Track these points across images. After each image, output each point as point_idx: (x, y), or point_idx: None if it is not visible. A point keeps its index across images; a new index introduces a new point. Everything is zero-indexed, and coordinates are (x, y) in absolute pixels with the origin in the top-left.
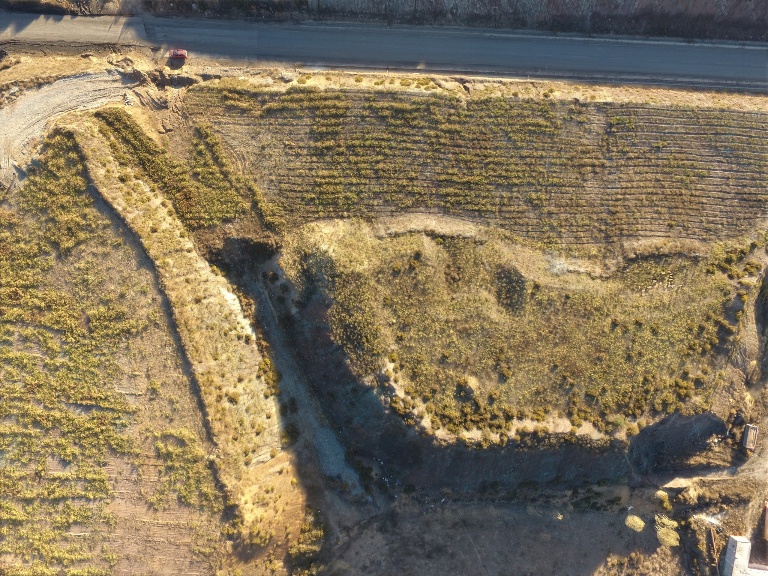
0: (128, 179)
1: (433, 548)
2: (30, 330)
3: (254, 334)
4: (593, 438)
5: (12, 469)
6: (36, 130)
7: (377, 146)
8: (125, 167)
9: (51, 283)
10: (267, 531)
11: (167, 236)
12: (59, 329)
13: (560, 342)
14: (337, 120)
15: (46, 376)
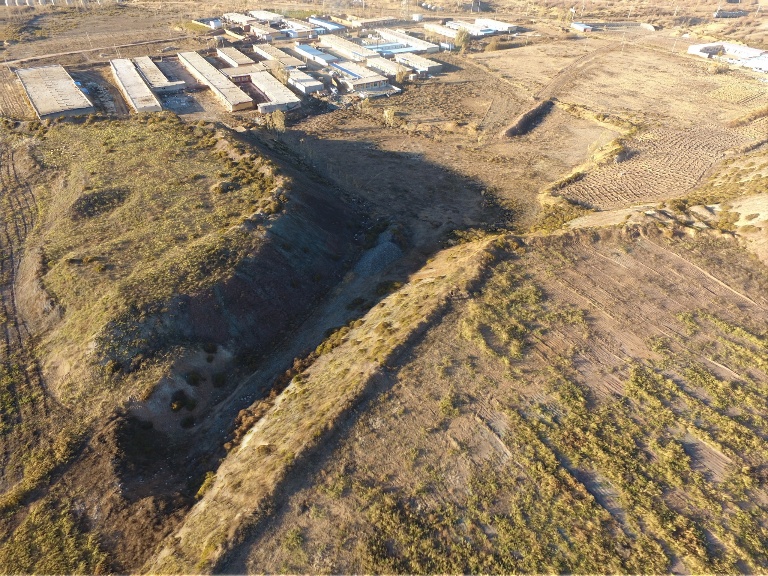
0: None
1: (397, 192)
2: None
3: None
4: None
5: None
6: None
7: None
8: None
9: None
10: None
11: None
12: None
13: None
14: None
15: None
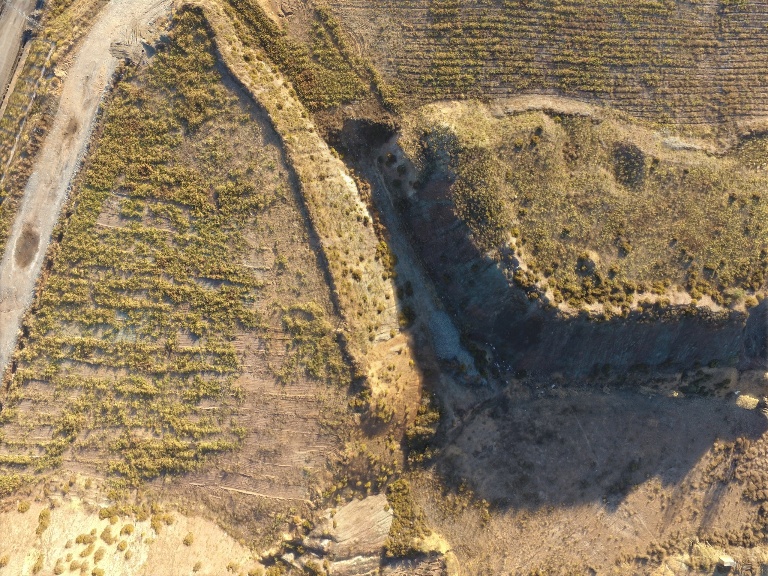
0: (252, 59)
1: (543, 434)
2: (160, 205)
3: (371, 217)
4: (713, 310)
5: (142, 343)
6: (161, 10)
7: (493, 28)
8: (248, 48)
9: (180, 159)
10: (390, 407)
11: (291, 114)
12: (188, 204)
13: (679, 217)
14: (454, 2)
15: (175, 251)
